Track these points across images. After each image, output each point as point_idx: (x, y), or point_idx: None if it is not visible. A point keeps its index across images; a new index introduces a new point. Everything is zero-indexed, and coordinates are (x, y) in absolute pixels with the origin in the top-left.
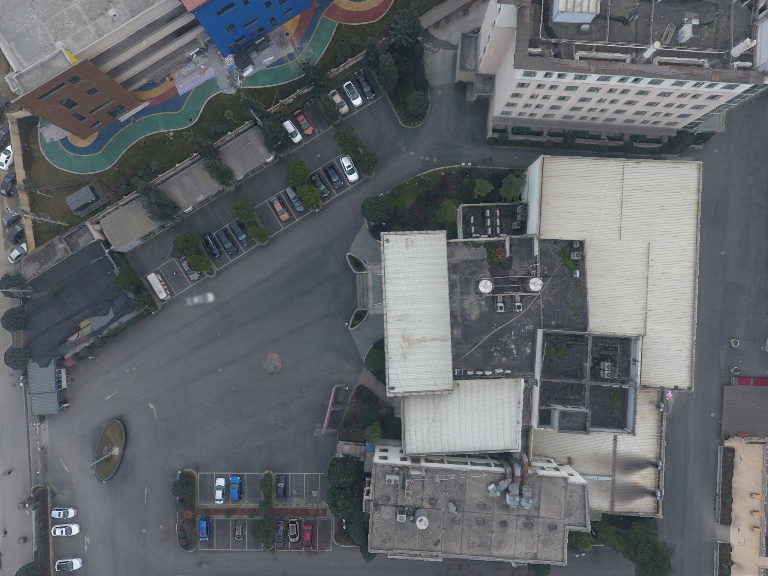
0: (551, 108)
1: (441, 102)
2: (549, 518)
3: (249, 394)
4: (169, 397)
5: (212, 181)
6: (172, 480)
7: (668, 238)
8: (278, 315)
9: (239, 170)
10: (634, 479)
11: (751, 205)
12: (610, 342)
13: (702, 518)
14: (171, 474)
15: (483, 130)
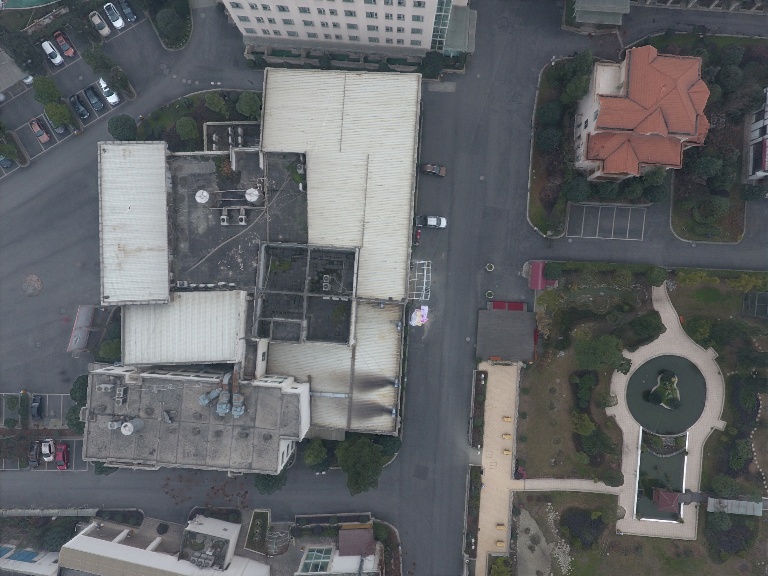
0: (285, 23)
1: (203, 25)
2: (265, 428)
3: (8, 315)
4: None
5: None
6: None
7: (387, 150)
8: (38, 237)
9: None
10: (372, 397)
11: (512, 130)
12: (335, 256)
13: (455, 441)
14: None
15: None
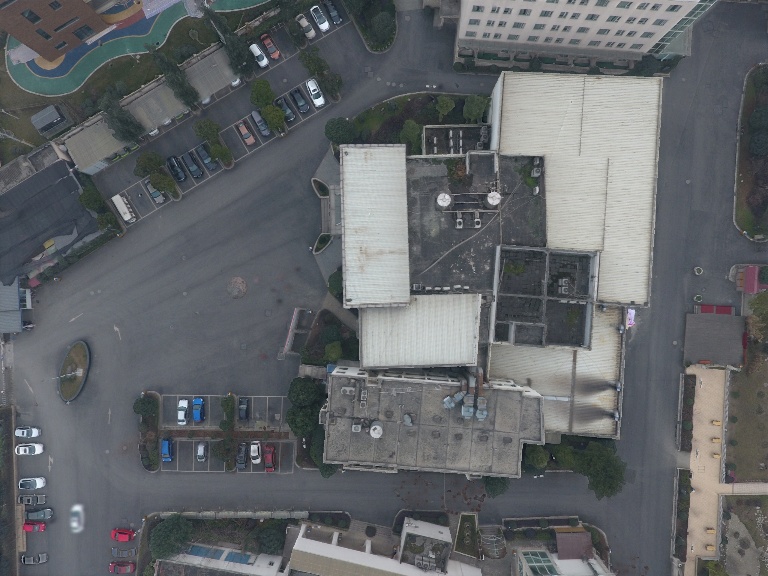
0: (514, 27)
1: (408, 28)
2: (504, 432)
3: (213, 317)
4: (133, 319)
5: (177, 102)
6: None
7: (627, 154)
8: (243, 239)
9: (204, 92)
10: (593, 401)
11: (717, 134)
12: (569, 260)
13: (663, 445)
14: (135, 396)
15: (450, 56)
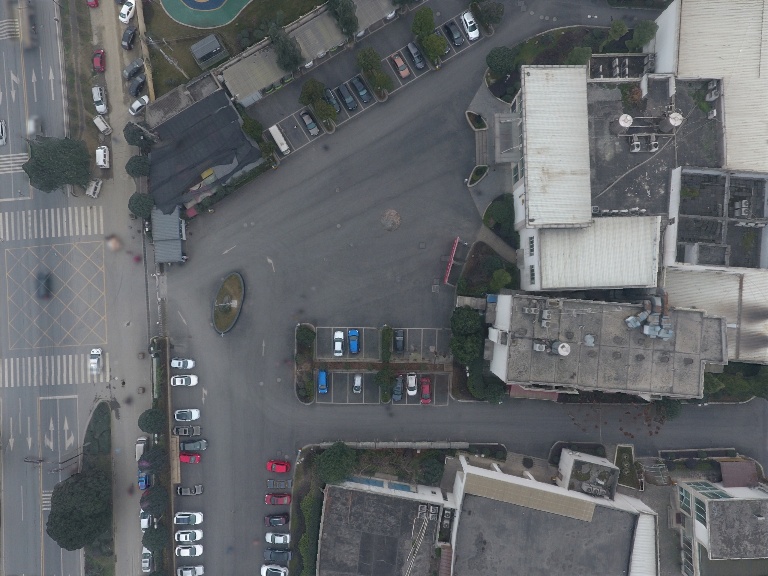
0: None
1: None
2: (685, 353)
3: (367, 250)
4: (287, 252)
5: (336, 33)
6: (290, 334)
7: None
8: (397, 172)
9: (363, 22)
10: (759, 328)
11: None
12: (744, 183)
13: None
14: (289, 328)
15: None
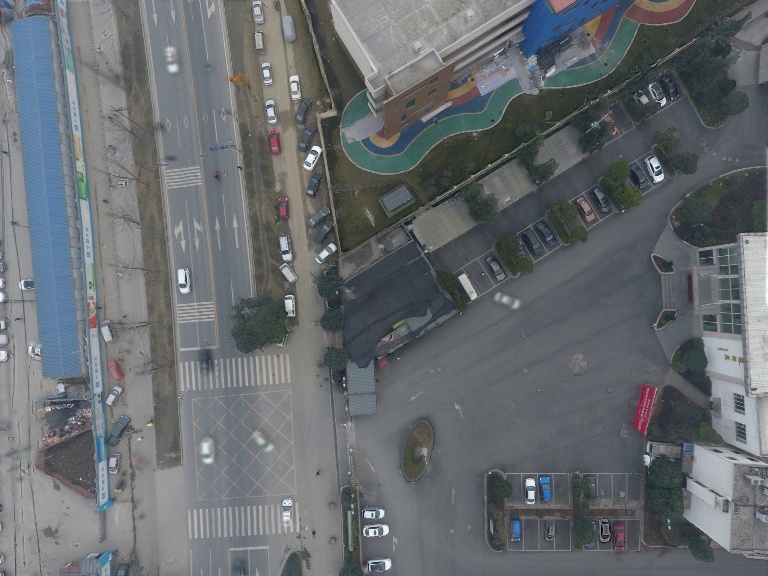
0: None
1: None
2: None
3: (555, 395)
4: (475, 398)
5: (525, 182)
6: (479, 480)
7: None
8: (583, 316)
9: None
10: None
11: None
12: None
13: None
14: (478, 474)
15: None
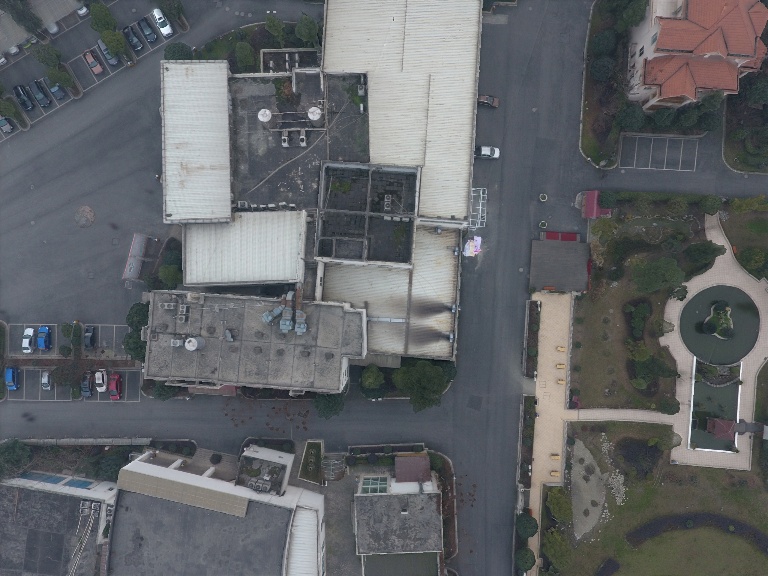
0: None
1: None
2: (326, 347)
3: (61, 246)
4: None
5: (21, 30)
6: None
7: (448, 70)
8: (91, 168)
9: (48, 19)
10: (429, 323)
11: (564, 62)
12: (396, 178)
13: (509, 372)
14: None
15: None
